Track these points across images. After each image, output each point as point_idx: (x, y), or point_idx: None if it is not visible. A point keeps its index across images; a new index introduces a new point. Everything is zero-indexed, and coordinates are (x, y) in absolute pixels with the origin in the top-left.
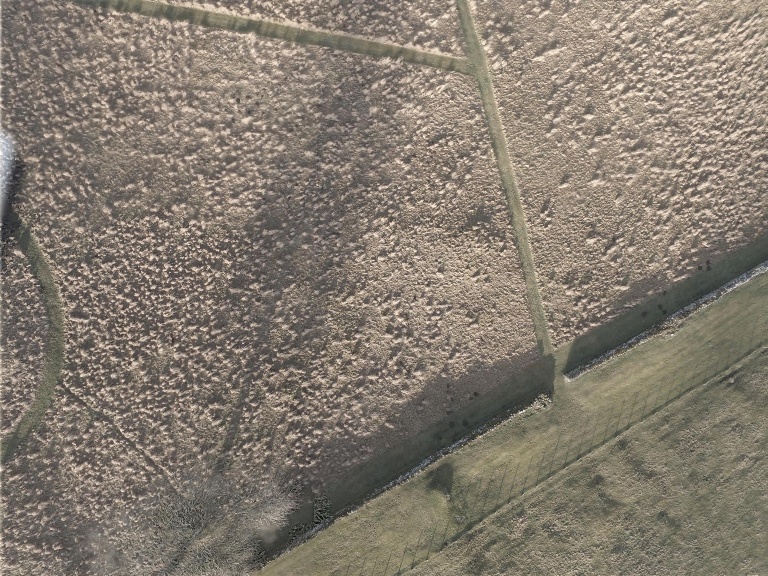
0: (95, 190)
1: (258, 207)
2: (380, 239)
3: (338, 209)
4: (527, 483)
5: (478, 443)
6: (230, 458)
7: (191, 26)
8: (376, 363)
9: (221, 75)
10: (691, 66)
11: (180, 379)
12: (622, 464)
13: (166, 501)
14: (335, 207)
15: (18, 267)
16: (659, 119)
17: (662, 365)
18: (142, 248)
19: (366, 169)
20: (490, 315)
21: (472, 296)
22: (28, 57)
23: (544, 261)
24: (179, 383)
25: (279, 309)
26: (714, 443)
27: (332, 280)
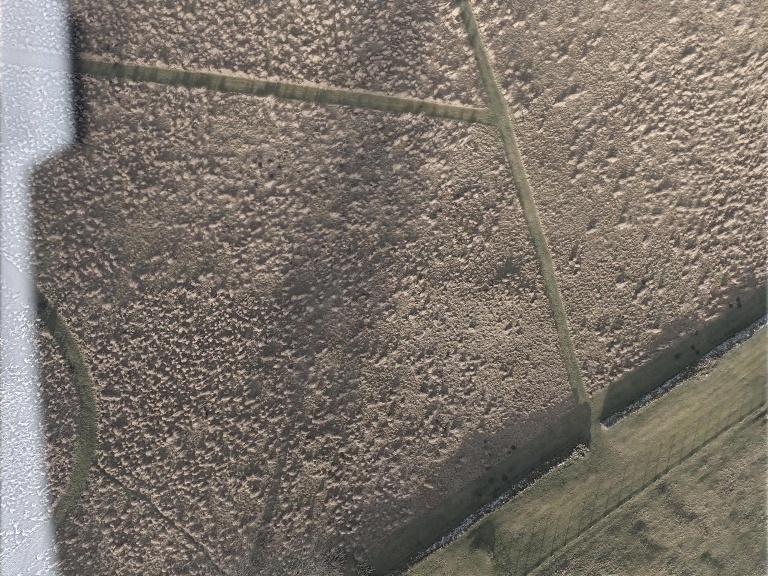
0: (120, 265)
1: (286, 272)
2: (410, 297)
3: (366, 269)
4: (569, 534)
5: (518, 498)
6: (270, 530)
7: (209, 92)
8: (412, 423)
9: (242, 140)
10: (712, 102)
11: (216, 452)
12: (663, 508)
13: None
14: (363, 267)
15: (47, 349)
16: (682, 158)
17: (698, 406)
18: (171, 321)
19: (392, 227)
20: (524, 367)
21: (505, 349)
22: (46, 133)
23: (575, 308)
24: (215, 457)
25: (312, 375)
26: (753, 481)
27: (364, 342)
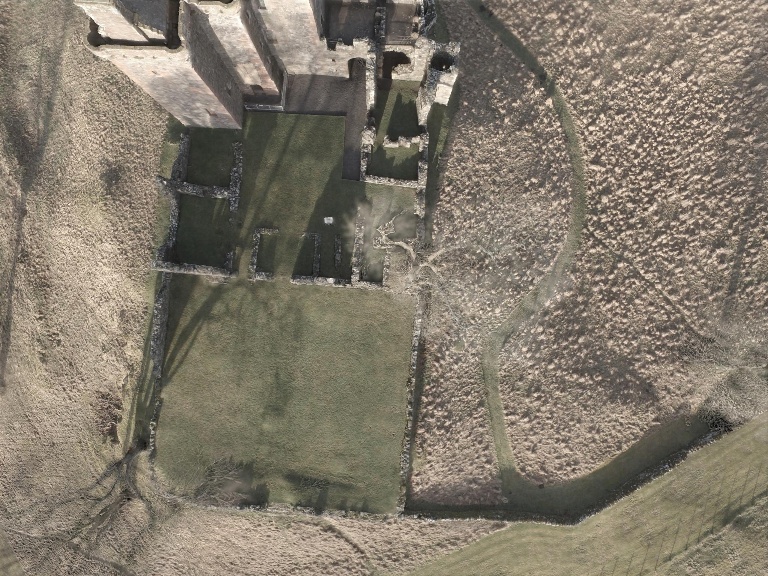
0: (605, 46)
1: (746, 64)
2: None
3: None
4: None
5: None
6: (735, 300)
7: None
8: None
9: None
10: None
11: (688, 225)
12: None
13: (686, 338)
14: None
15: (548, 116)
16: None
17: None
18: (647, 102)
19: None
20: None
21: None
22: None
23: None
24: (687, 229)
25: None
26: None
27: None
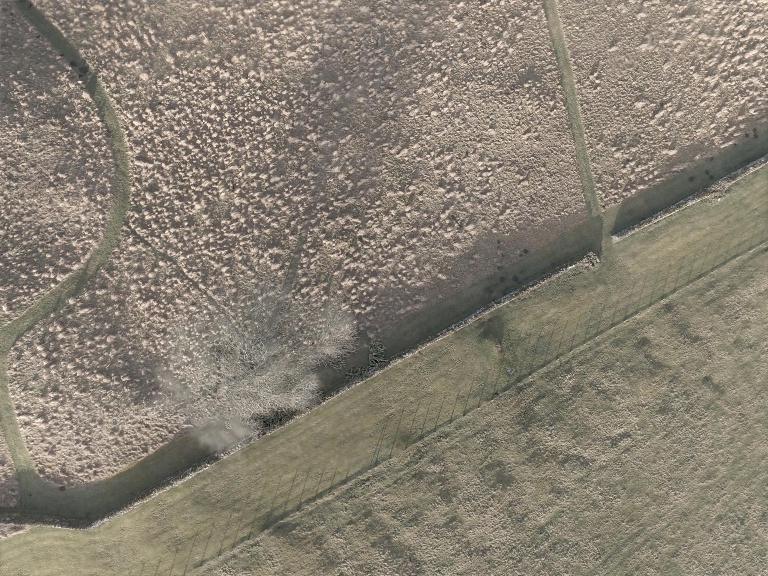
0: (158, 40)
1: (315, 61)
2: (433, 94)
3: (392, 64)
4: (575, 341)
5: (528, 298)
6: (289, 301)
7: None
8: (429, 216)
9: None
10: None
11: (241, 224)
12: (668, 327)
13: (228, 339)
14: (389, 62)
15: (86, 110)
16: None
17: (708, 230)
18: (203, 97)
19: (419, 26)
20: (540, 174)
21: (522, 154)
22: None
23: (593, 123)
24: (240, 228)
25: (335, 160)
26: (759, 311)
27: (387, 133)
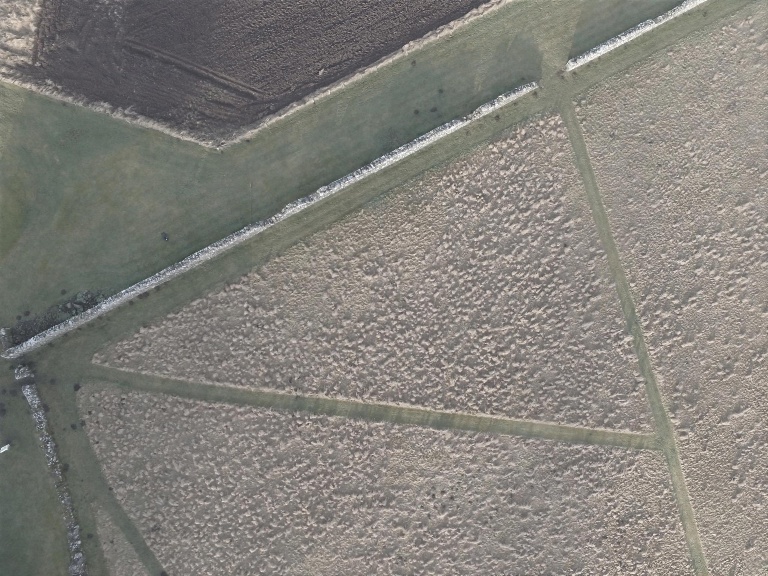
0: None
1: None
2: None
3: None
4: None
5: None
6: None
7: (386, 424)
8: None
9: (417, 473)
10: None
11: None
12: None
13: None
14: None
15: None
16: None
17: None
18: None
19: (559, 555)
20: None
21: None
22: (231, 469)
23: None
24: None
25: None
26: None
27: None
